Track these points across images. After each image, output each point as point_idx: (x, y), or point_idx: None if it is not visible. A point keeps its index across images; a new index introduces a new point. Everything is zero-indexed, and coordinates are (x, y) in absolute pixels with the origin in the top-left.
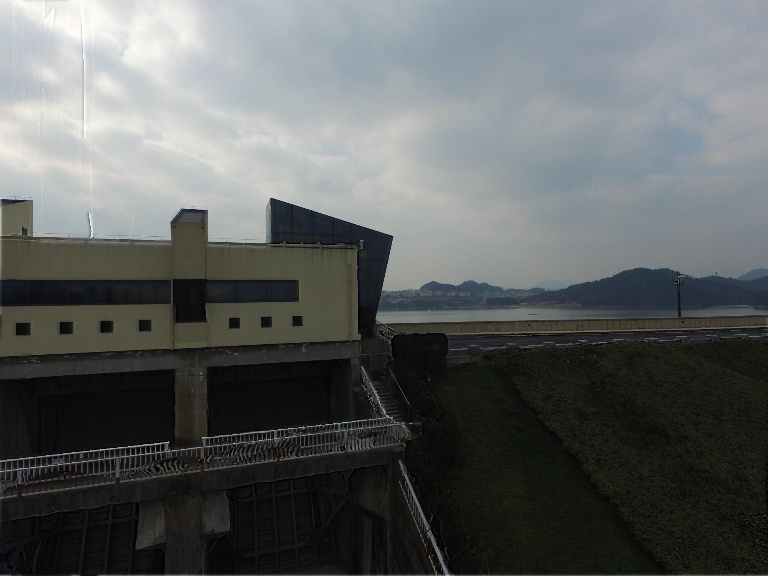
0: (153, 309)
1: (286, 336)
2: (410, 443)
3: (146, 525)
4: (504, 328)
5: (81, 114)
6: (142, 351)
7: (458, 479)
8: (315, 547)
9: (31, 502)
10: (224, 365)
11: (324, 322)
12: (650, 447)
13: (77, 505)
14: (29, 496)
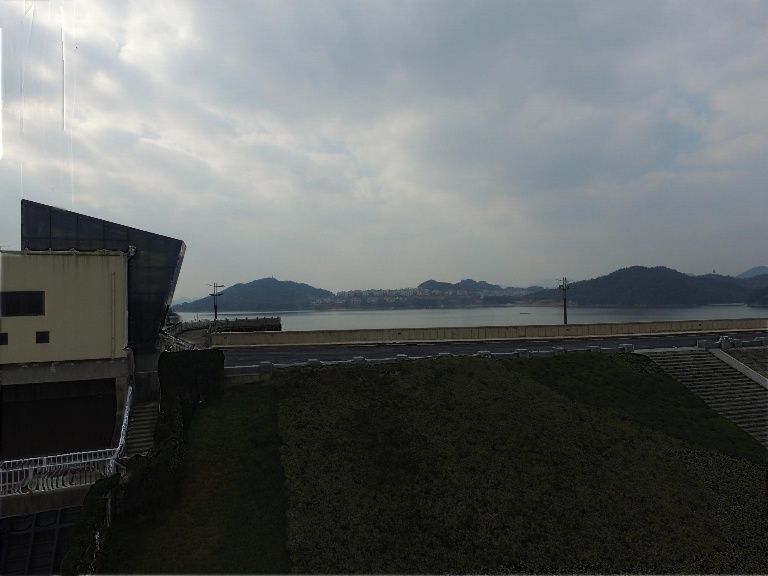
0: None
1: (28, 354)
2: (95, 484)
3: None
4: (372, 337)
5: (61, 113)
6: None
7: (163, 523)
8: None
9: None
10: None
11: (79, 338)
12: (384, 486)
13: None
14: None
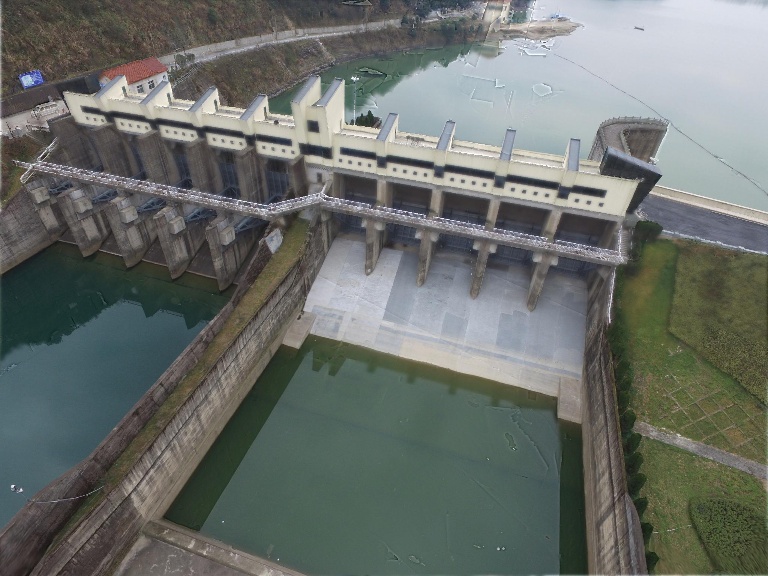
0: (551, 191)
1: (594, 209)
2: (620, 265)
3: (537, 257)
4: (734, 210)
5: None
6: (544, 203)
7: (632, 280)
8: (579, 273)
9: (515, 244)
10: None
11: (612, 207)
12: (707, 299)
13: (524, 248)
14: (515, 243)
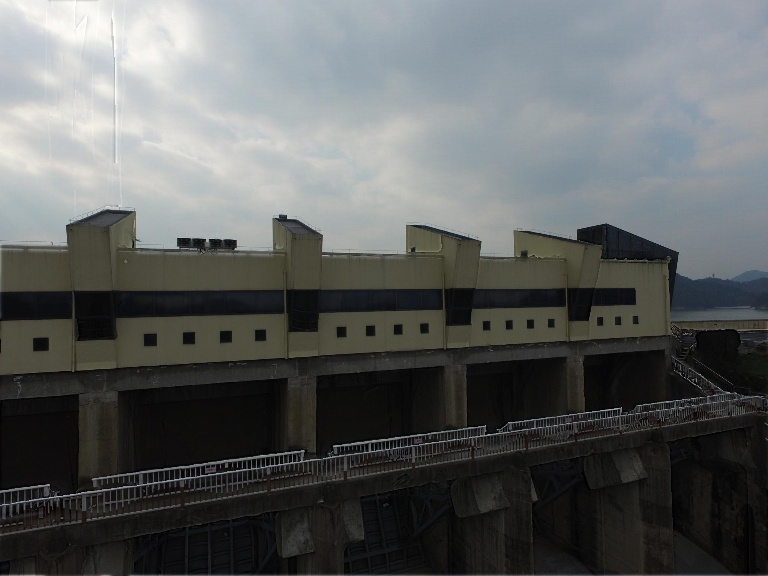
0: (555, 311)
1: (629, 332)
2: None
3: (625, 466)
4: (695, 327)
5: (113, 119)
6: (549, 343)
7: None
8: None
9: (582, 446)
10: (593, 354)
11: (650, 321)
12: None
13: (603, 449)
14: (580, 441)
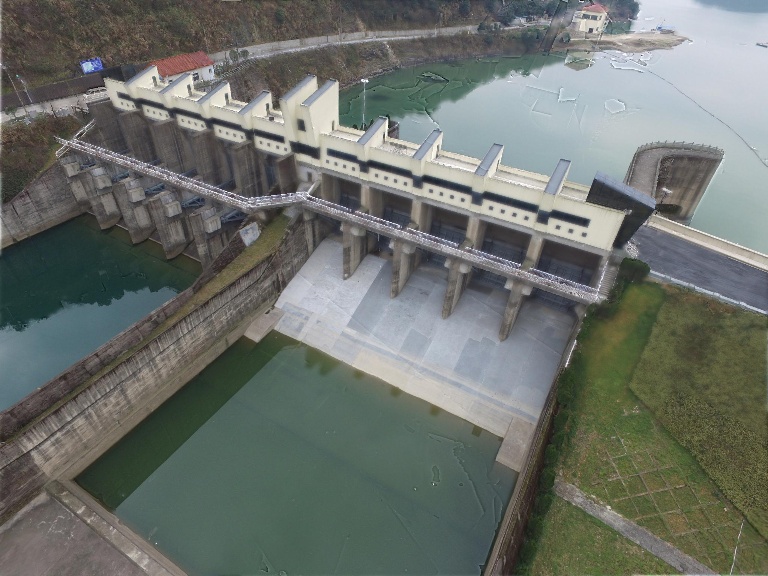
0: (531, 214)
1: (577, 238)
2: (592, 305)
3: (508, 283)
4: (757, 259)
5: None
6: (523, 226)
7: (606, 323)
8: (568, 308)
9: (484, 267)
10: None
11: (596, 239)
12: (684, 358)
13: (494, 272)
14: (484, 265)
